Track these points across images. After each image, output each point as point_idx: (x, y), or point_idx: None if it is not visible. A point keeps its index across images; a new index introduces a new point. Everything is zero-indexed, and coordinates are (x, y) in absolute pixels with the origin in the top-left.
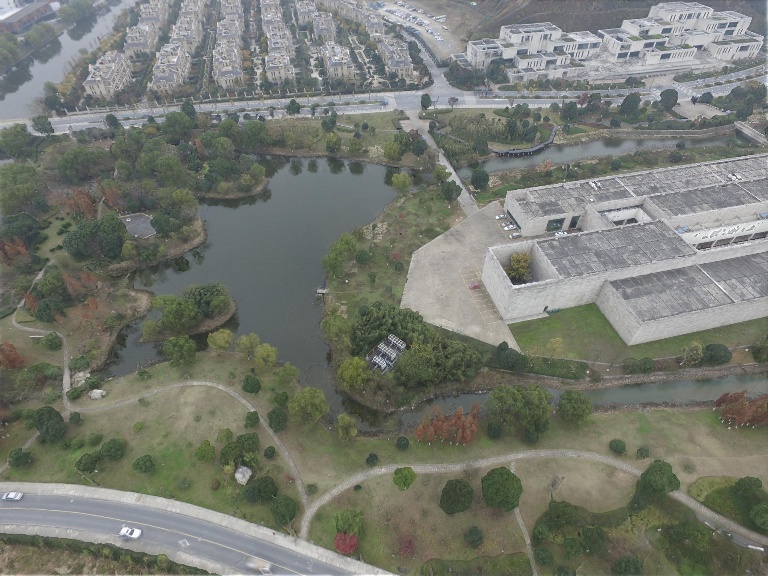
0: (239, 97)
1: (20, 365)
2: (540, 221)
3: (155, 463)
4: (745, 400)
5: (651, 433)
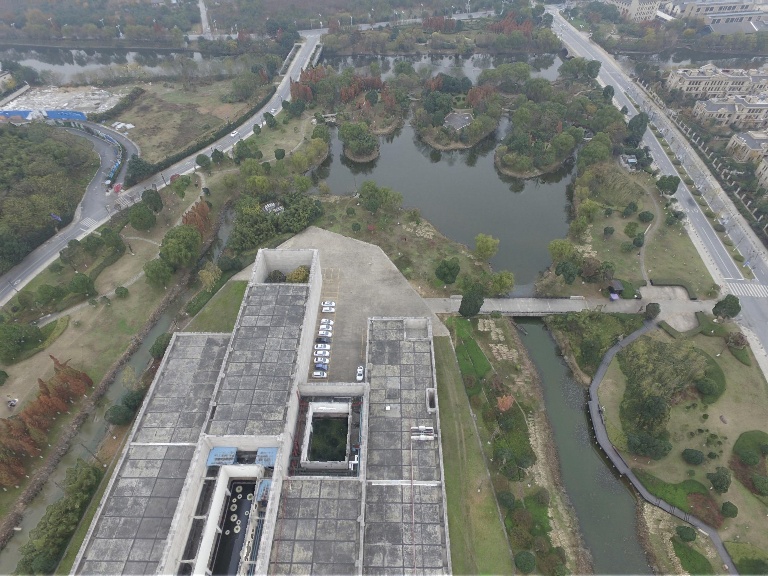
0: (709, 159)
1: (343, 100)
2: None
3: (262, 137)
4: (64, 369)
5: (116, 325)
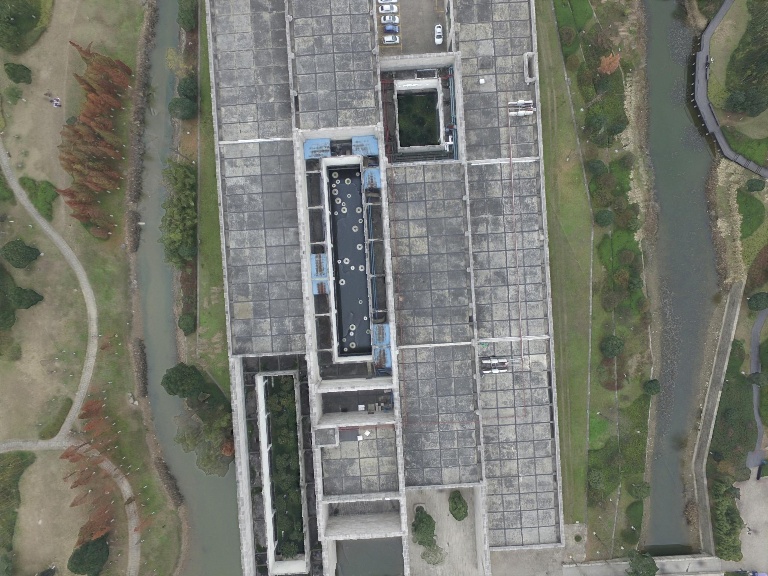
0: None
1: None
2: None
3: None
4: (95, 58)
5: None
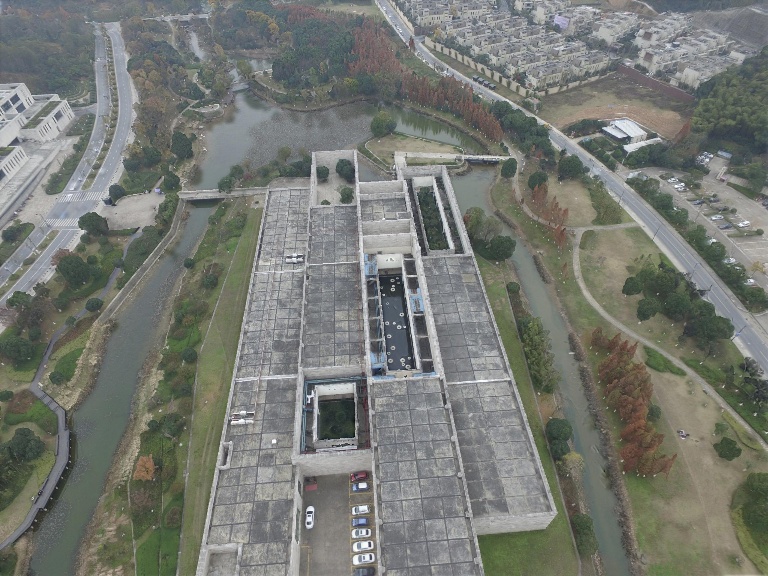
0: None
1: None
2: (293, 557)
3: None
4: (652, 453)
5: (685, 575)
